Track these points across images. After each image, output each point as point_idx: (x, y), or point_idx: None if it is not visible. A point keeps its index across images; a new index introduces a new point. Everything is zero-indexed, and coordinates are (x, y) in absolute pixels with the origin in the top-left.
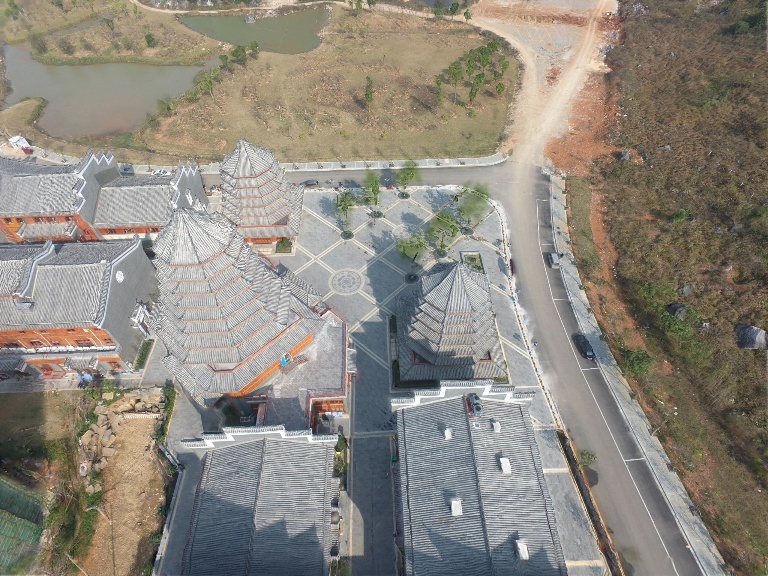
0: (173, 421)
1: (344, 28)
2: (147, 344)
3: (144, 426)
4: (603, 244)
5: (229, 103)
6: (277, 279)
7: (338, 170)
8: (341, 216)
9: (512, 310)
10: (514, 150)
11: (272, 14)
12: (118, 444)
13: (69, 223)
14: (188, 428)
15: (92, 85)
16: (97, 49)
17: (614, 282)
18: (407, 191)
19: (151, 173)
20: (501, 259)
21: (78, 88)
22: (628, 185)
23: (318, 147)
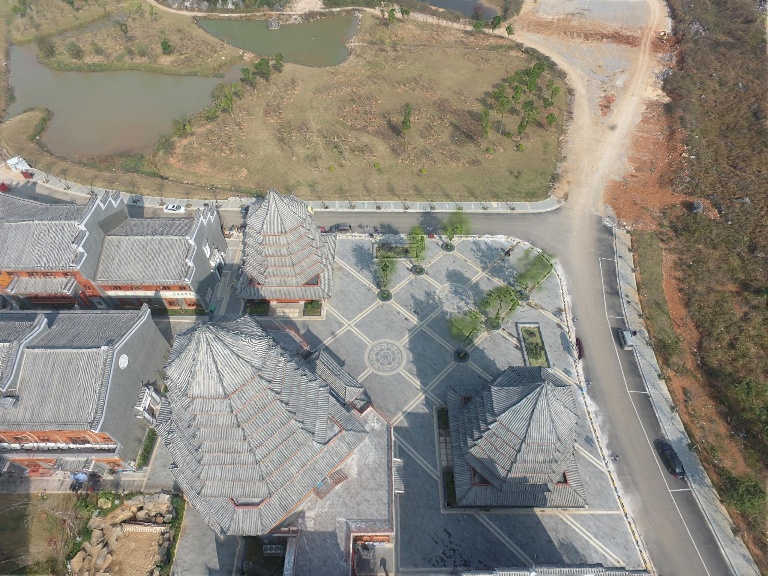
0: (181, 542)
1: (375, 39)
2: (153, 432)
3: (146, 542)
4: (681, 319)
5: (251, 124)
6: (314, 382)
7: (372, 211)
8: (377, 270)
9: (581, 404)
10: (570, 194)
11: (297, 20)
12: (115, 567)
13: (67, 278)
14: (199, 553)
15: (102, 95)
16: (109, 54)
17: (698, 371)
18: (451, 241)
19: (163, 208)
20: (564, 334)
21: (86, 98)
22: (704, 245)
23: (349, 182)
